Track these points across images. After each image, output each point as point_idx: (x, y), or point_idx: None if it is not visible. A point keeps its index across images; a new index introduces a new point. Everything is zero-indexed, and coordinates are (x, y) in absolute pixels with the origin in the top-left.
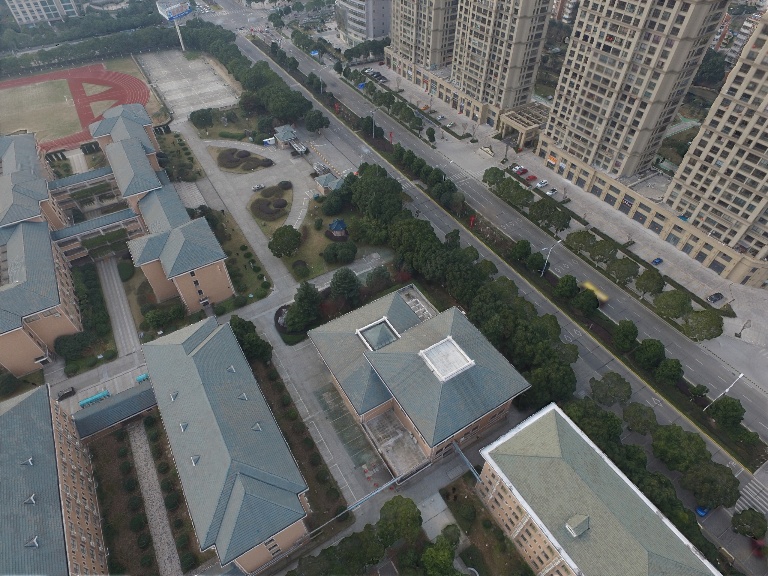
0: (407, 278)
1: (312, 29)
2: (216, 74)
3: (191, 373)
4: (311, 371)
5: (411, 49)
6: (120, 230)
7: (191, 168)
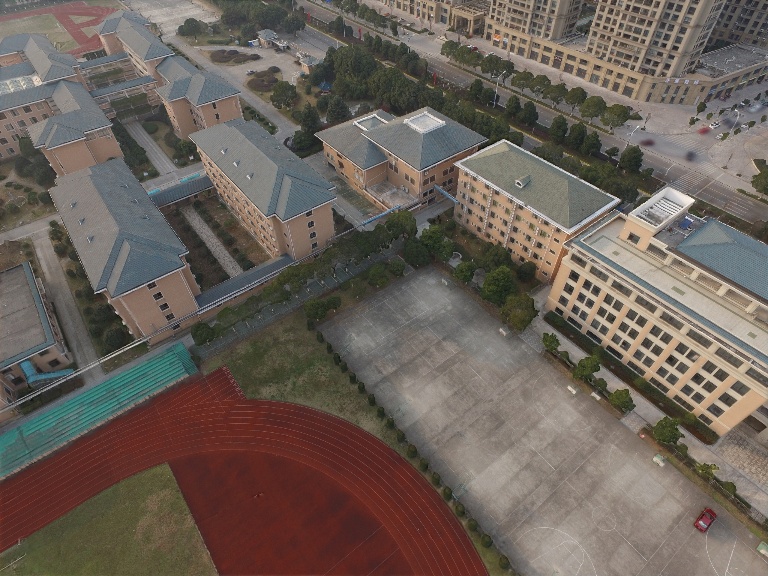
0: (387, 110)
1: None
2: (193, 3)
3: (235, 135)
4: (319, 171)
5: None
6: (142, 94)
7: None
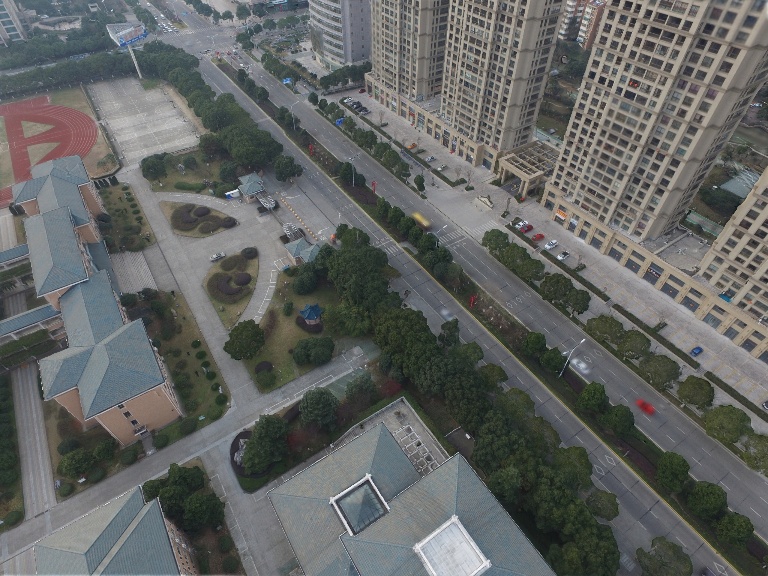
0: (396, 390)
1: (285, 50)
2: (176, 107)
3: None
4: (275, 534)
5: (394, 78)
6: (39, 332)
7: (139, 232)
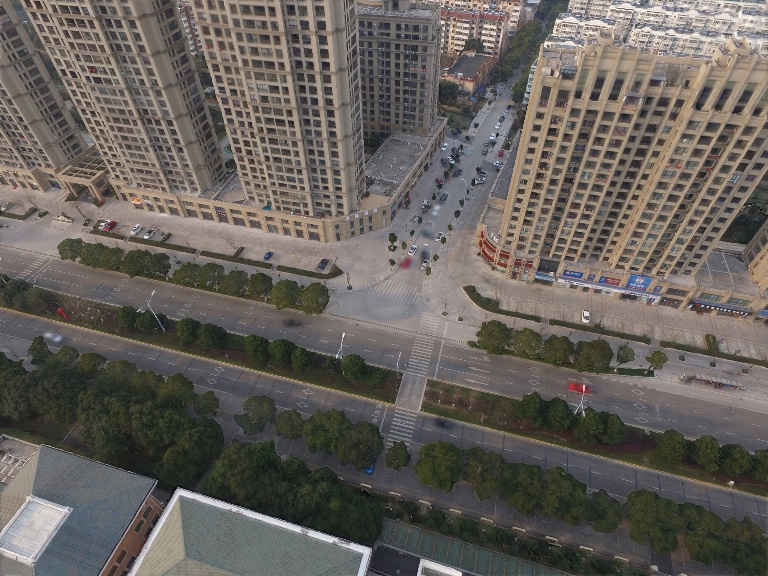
0: None
1: None
2: None
3: None
4: None
5: None
6: None
7: None
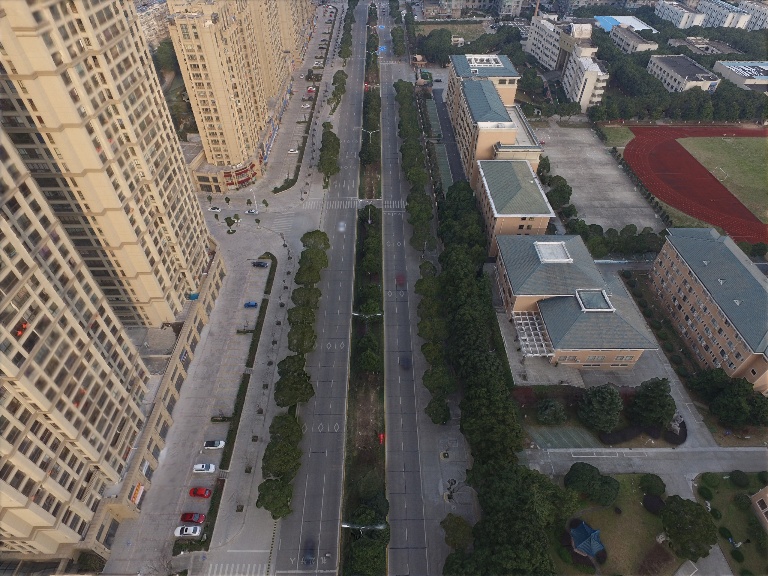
0: None
1: None
2: None
3: None
4: (643, 362)
5: None
6: None
7: None
